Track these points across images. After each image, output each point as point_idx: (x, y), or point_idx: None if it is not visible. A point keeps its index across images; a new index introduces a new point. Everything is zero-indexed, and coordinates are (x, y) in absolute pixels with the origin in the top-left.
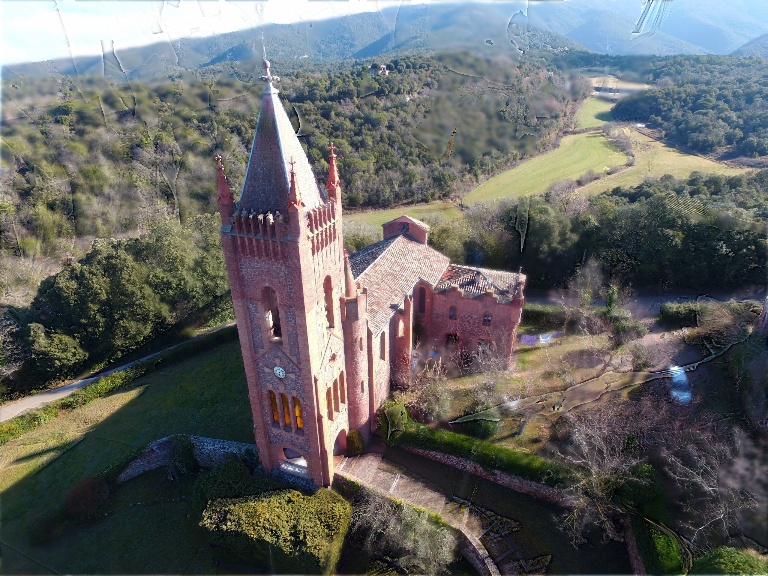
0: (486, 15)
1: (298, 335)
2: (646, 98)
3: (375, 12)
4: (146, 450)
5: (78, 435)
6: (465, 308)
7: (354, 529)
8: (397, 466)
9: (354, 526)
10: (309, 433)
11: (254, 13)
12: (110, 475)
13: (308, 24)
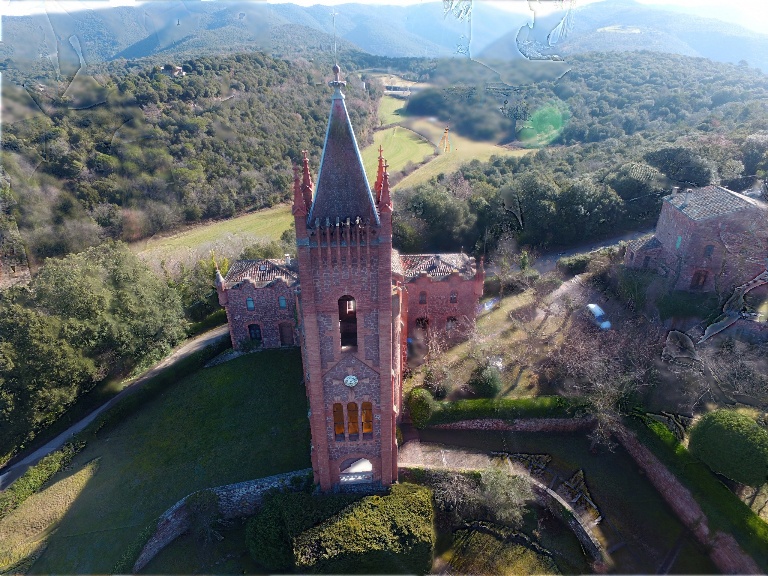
0: (504, 26)
1: (380, 337)
2: None
3: (229, 11)
4: (160, 523)
5: (35, 545)
6: (434, 291)
7: (442, 508)
8: (436, 444)
9: (441, 505)
10: (382, 433)
11: (98, 6)
12: (126, 568)
13: (157, 21)
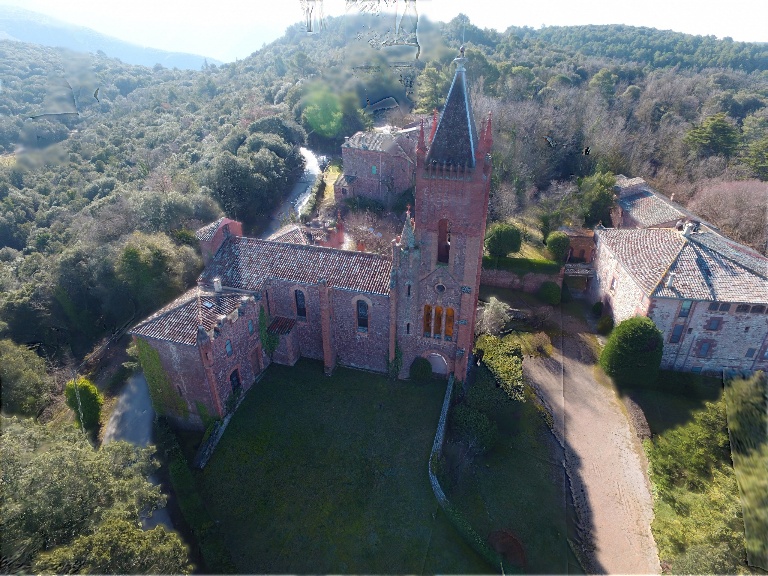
0: (421, 22)
1: None
2: (100, 86)
3: None
4: None
5: None
6: None
7: None
8: None
9: None
10: None
11: None
12: None
13: None
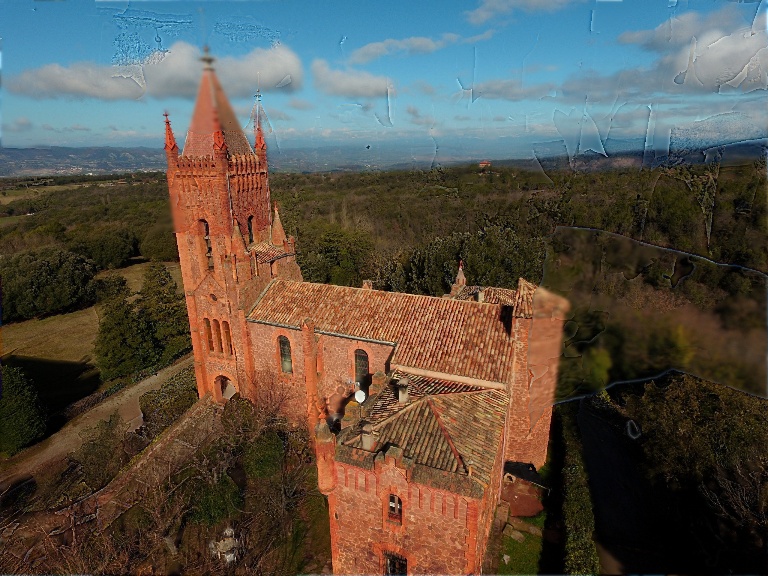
0: None
1: None
2: None
3: None
4: None
5: None
6: None
7: None
8: None
9: None
10: None
11: None
12: None
13: None
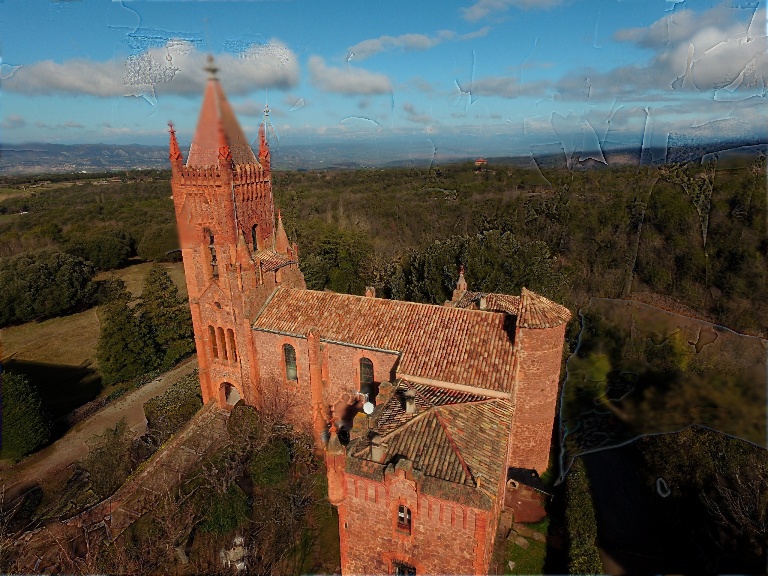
0: None
1: None
2: None
3: None
4: None
5: None
6: None
7: None
8: None
9: None
10: None
11: None
12: None
13: None
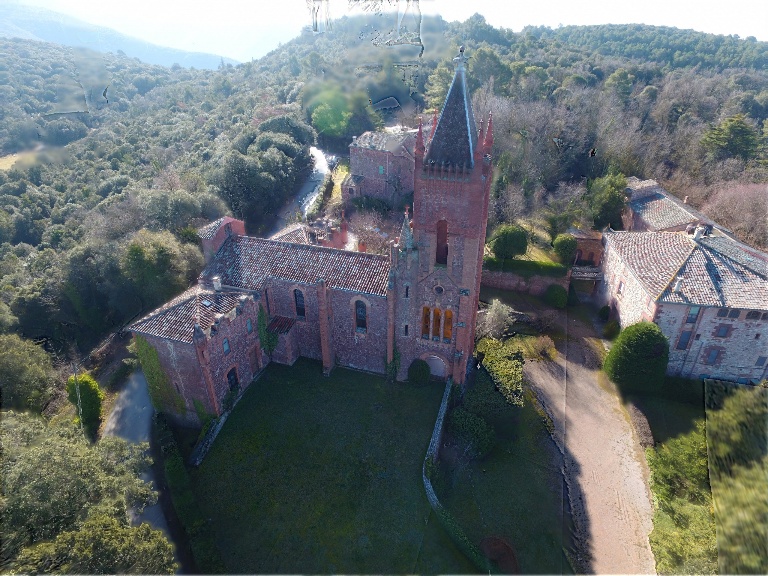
0: (424, 22)
1: None
2: (112, 85)
3: None
4: None
5: None
6: None
7: None
8: None
9: None
10: None
11: None
12: None
13: None
